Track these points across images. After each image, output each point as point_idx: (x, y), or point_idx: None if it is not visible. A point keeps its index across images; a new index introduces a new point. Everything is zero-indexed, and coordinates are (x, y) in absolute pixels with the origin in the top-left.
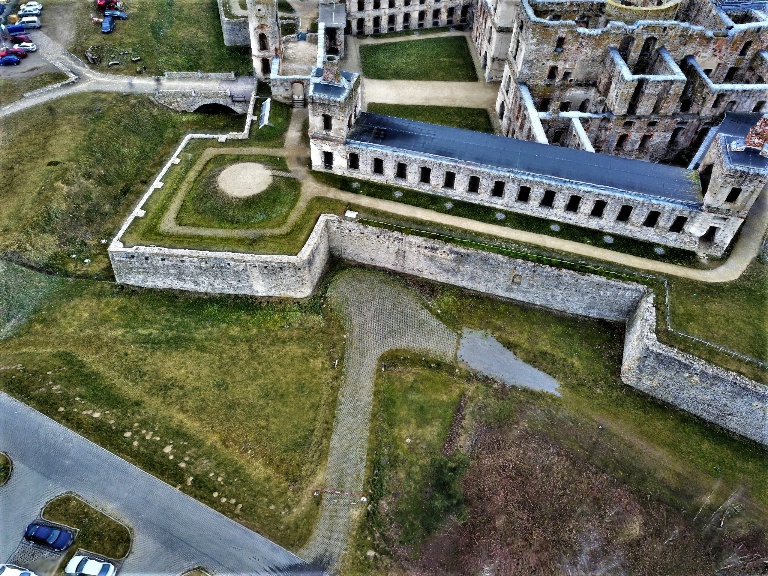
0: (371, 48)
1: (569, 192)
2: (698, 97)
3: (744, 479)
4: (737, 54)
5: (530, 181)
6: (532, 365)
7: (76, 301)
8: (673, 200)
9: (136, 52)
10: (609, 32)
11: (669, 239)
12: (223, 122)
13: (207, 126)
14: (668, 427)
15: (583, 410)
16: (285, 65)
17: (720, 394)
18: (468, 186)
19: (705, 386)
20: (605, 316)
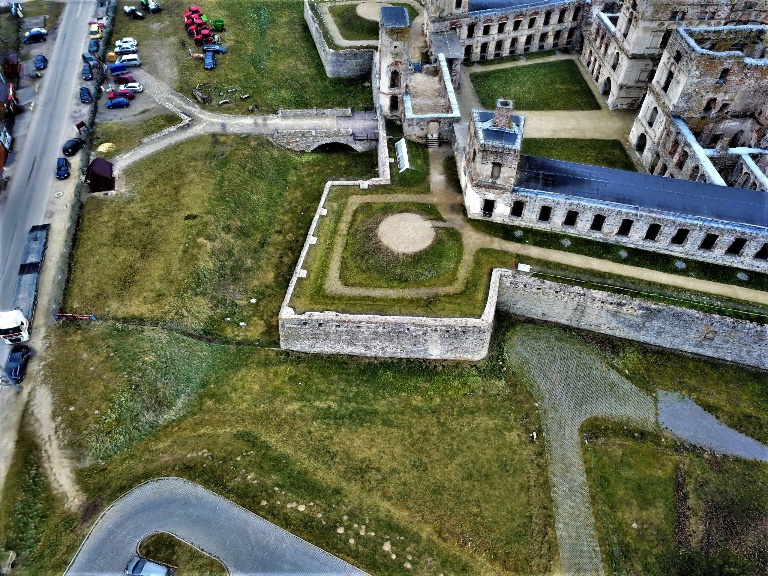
0: (482, 76)
1: (764, 240)
2: None
3: None
4: None
5: (721, 229)
6: (738, 430)
7: (243, 371)
8: None
9: (243, 89)
10: None
11: None
12: (344, 162)
13: (329, 167)
14: None
15: None
16: None
17: None
18: (645, 233)
19: None
20: None
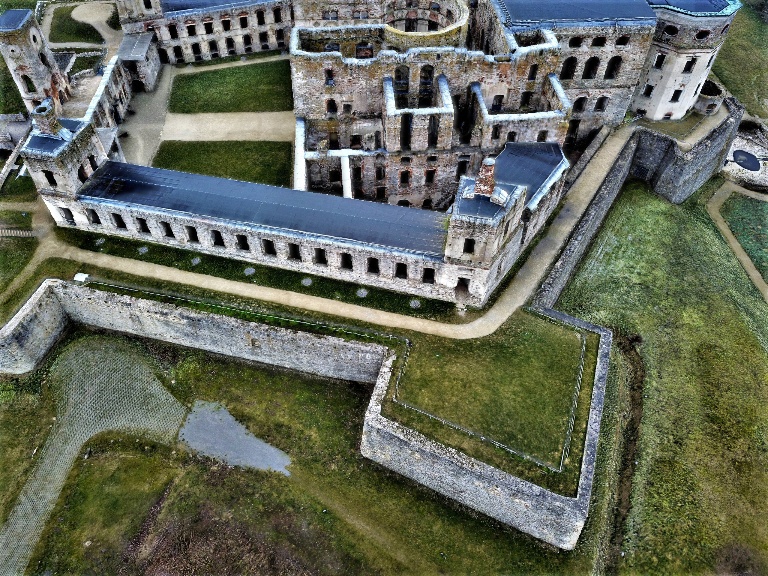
0: (187, 78)
1: (310, 245)
2: (475, 129)
3: (472, 566)
4: (525, 78)
5: (268, 235)
6: (264, 440)
7: None
8: (415, 251)
9: None
10: (378, 62)
11: (425, 291)
12: None
13: None
14: (401, 507)
15: (310, 491)
16: (69, 104)
17: (444, 472)
18: (213, 240)
19: (429, 463)
20: (357, 378)
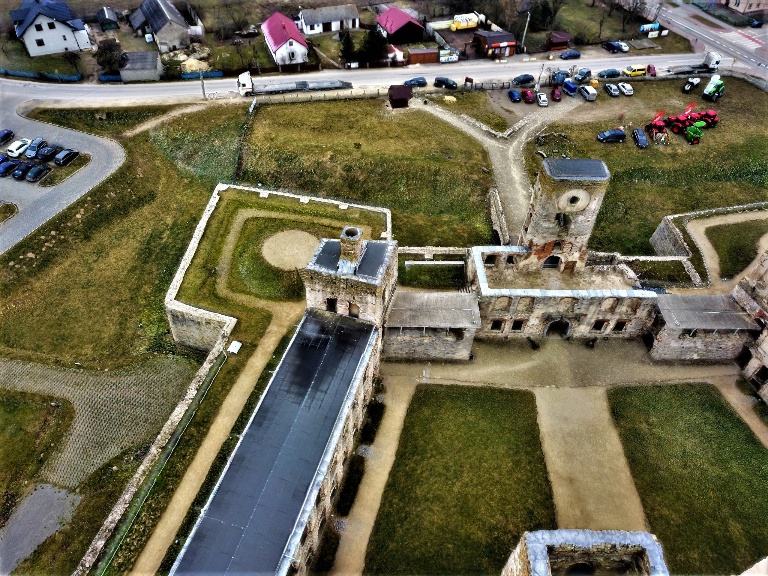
0: (712, 400)
1: None
2: None
3: None
4: None
5: None
6: None
7: (207, 194)
8: None
9: None
10: None
11: None
12: None
13: (468, 243)
14: None
15: None
16: (553, 274)
17: None
18: None
19: None
20: None
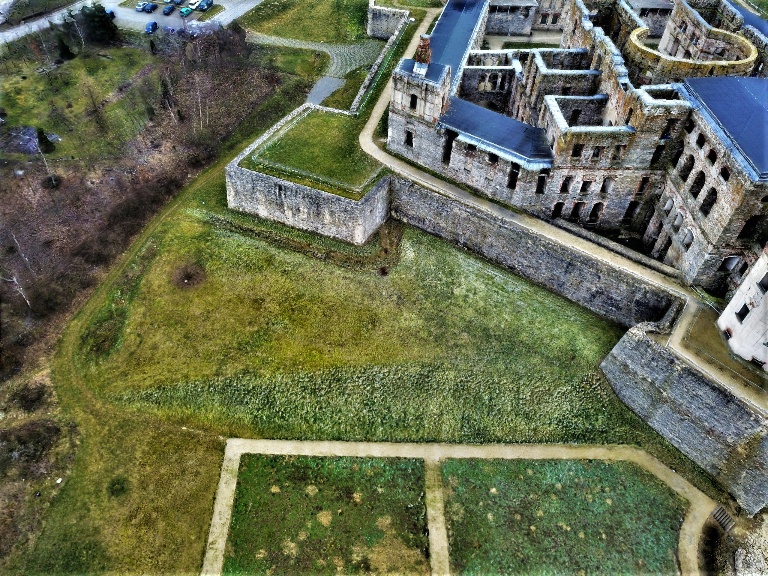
0: None
1: None
2: None
3: None
4: None
5: None
6: None
7: None
8: None
9: None
10: None
11: None
12: None
13: None
14: None
15: None
16: None
17: None
18: None
19: None
20: None
